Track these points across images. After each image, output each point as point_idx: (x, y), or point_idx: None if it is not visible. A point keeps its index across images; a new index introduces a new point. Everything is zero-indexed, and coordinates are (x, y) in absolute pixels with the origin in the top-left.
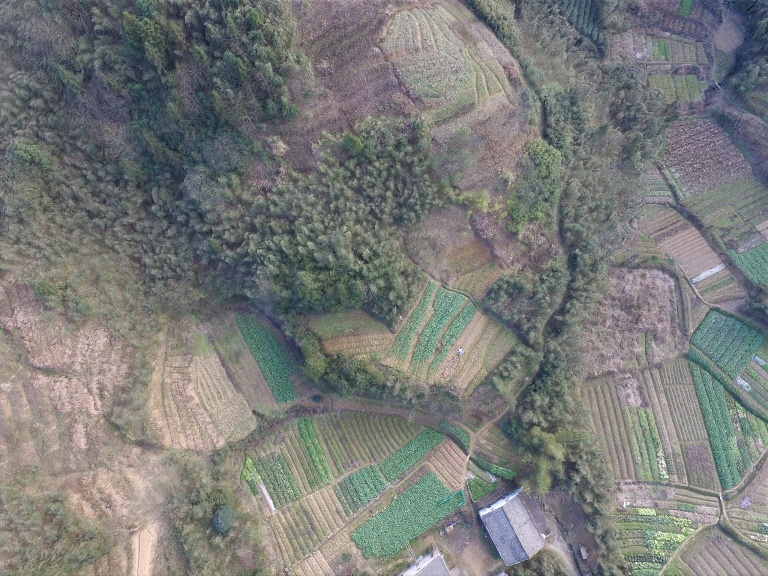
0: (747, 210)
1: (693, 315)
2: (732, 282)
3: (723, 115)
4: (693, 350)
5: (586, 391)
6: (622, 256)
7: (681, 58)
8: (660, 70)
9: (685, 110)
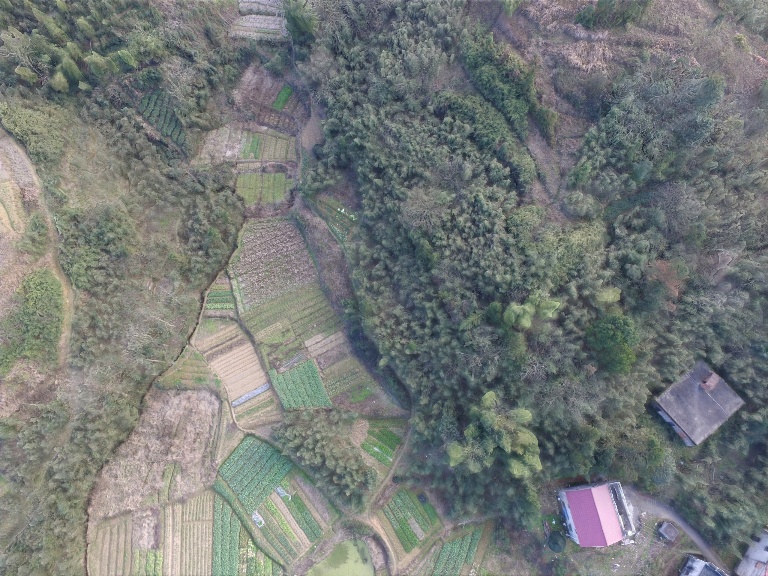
0: (301, 323)
1: (224, 443)
2: (271, 404)
3: (296, 218)
4: (218, 482)
5: (101, 532)
6: (171, 377)
7: (270, 155)
8: (249, 168)
9: (270, 211)
